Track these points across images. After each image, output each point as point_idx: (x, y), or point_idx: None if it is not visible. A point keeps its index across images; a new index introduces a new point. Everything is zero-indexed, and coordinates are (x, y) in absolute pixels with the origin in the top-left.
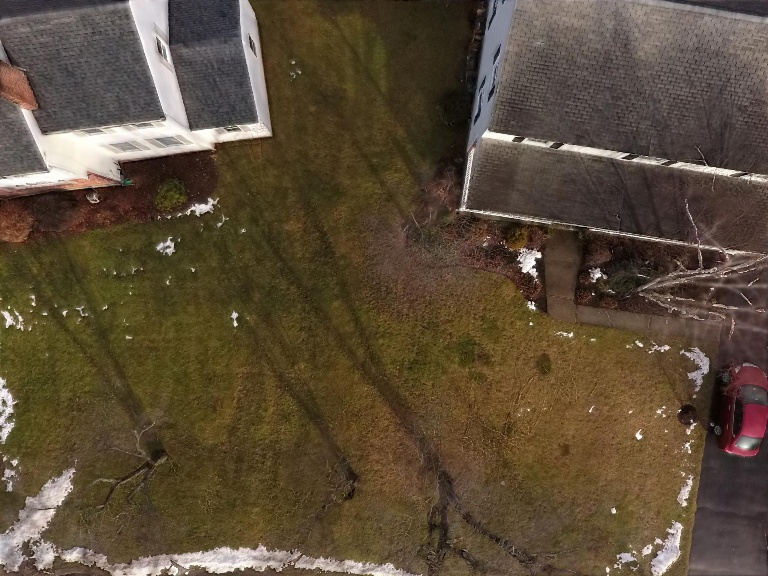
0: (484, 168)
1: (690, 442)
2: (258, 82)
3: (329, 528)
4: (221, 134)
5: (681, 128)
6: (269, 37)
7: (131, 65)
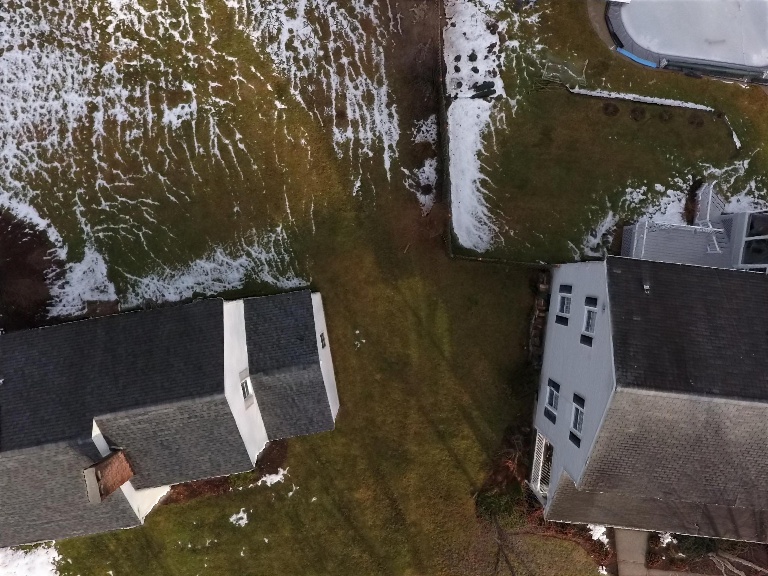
0: (565, 491)
1: None
2: (329, 376)
3: None
4: None
5: None
6: (333, 308)
7: (224, 436)
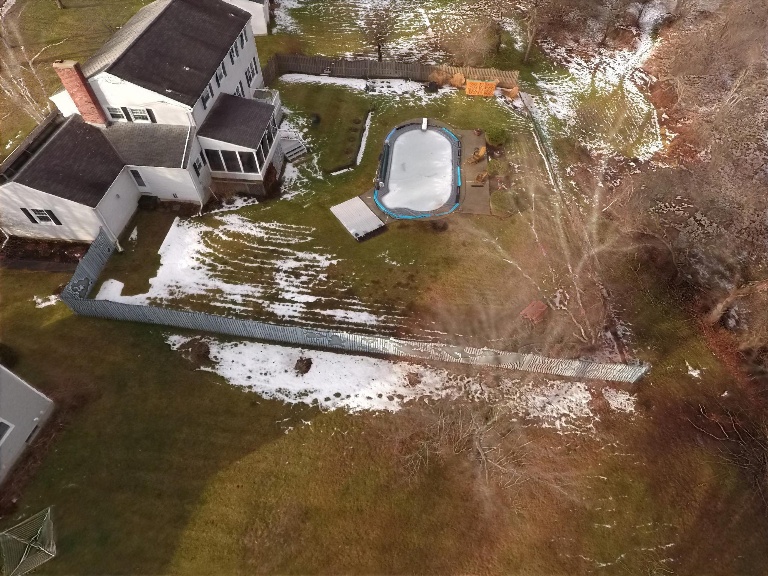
0: None
1: None
2: None
3: None
4: None
5: None
6: None
7: None
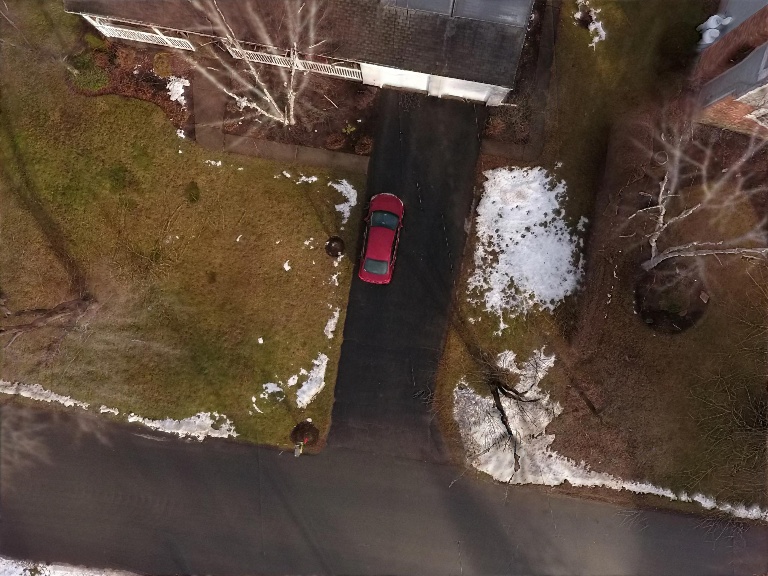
0: None
1: (337, 274)
2: None
3: None
4: None
5: None
6: None
7: None
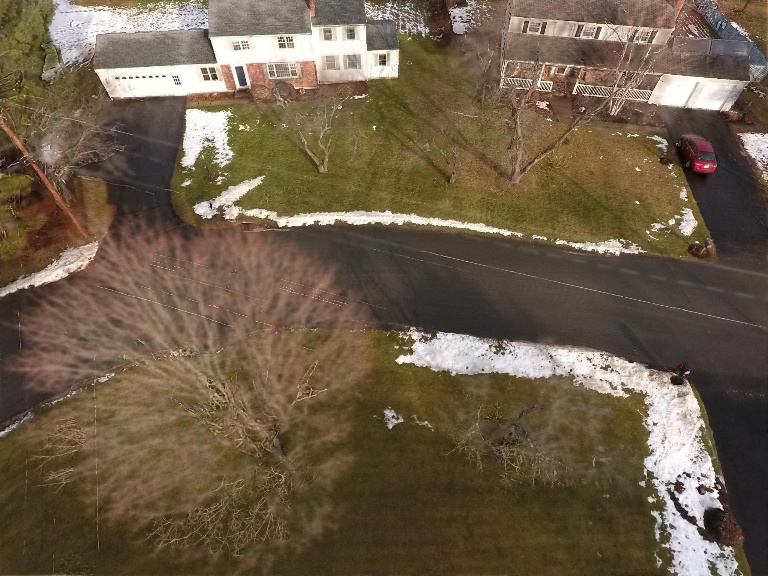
0: (511, 44)
1: (674, 172)
2: None
3: (437, 202)
4: (375, 67)
5: (595, 12)
6: None
7: (358, 6)
